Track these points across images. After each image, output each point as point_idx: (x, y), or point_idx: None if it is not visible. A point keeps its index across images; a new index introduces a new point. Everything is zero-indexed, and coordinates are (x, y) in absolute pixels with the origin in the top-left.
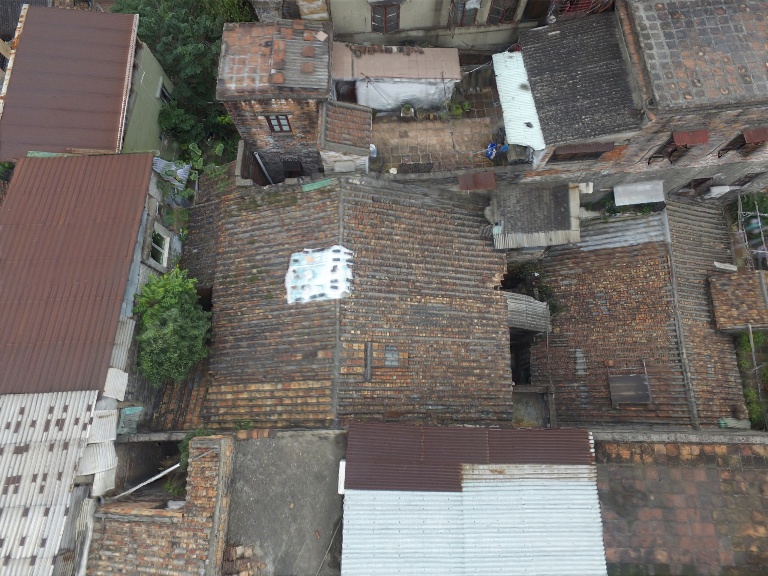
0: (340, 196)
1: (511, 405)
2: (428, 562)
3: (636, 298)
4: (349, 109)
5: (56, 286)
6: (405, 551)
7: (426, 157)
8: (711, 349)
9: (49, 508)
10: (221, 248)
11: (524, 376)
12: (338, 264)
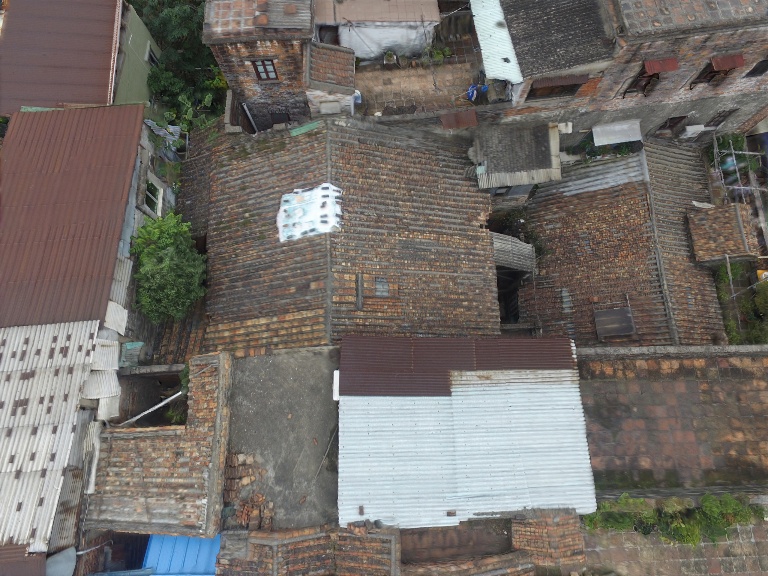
0: (327, 137)
1: (499, 335)
2: (421, 460)
3: (618, 236)
4: (332, 50)
5: (54, 228)
6: (399, 451)
7: (410, 102)
8: (691, 282)
9: (57, 426)
10: (213, 197)
11: (514, 322)
12: (327, 200)
